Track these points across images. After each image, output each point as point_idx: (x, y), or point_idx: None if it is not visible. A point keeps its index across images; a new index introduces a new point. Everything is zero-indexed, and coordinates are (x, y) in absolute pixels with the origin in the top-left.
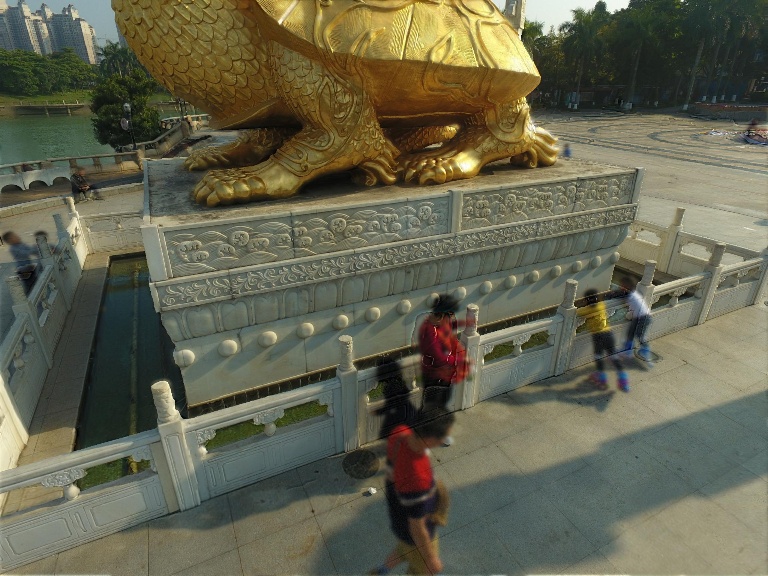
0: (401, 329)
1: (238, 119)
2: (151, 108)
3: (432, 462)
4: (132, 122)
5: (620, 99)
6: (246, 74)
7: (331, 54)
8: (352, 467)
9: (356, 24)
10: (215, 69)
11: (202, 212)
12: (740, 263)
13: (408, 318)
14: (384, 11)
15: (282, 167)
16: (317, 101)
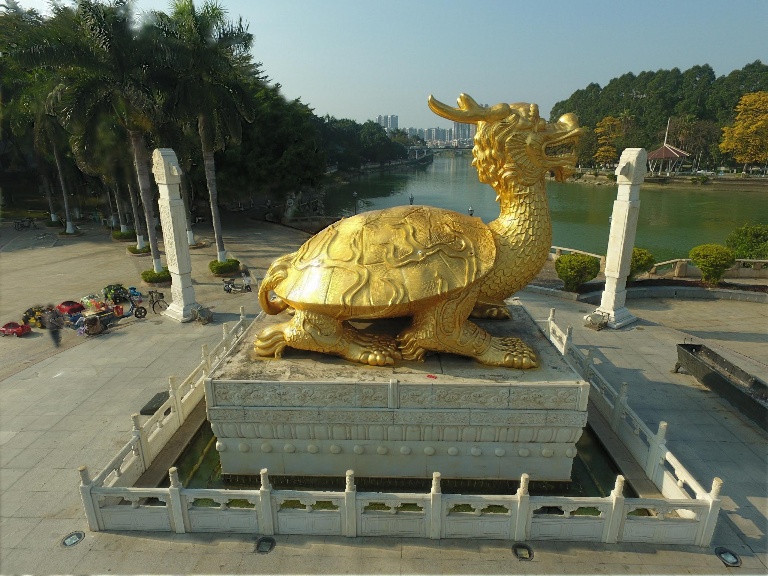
0: None
1: None
2: None
3: None
4: None
5: None
6: None
7: None
8: None
9: None
10: None
11: None
12: None
13: None
14: None
15: None
16: None
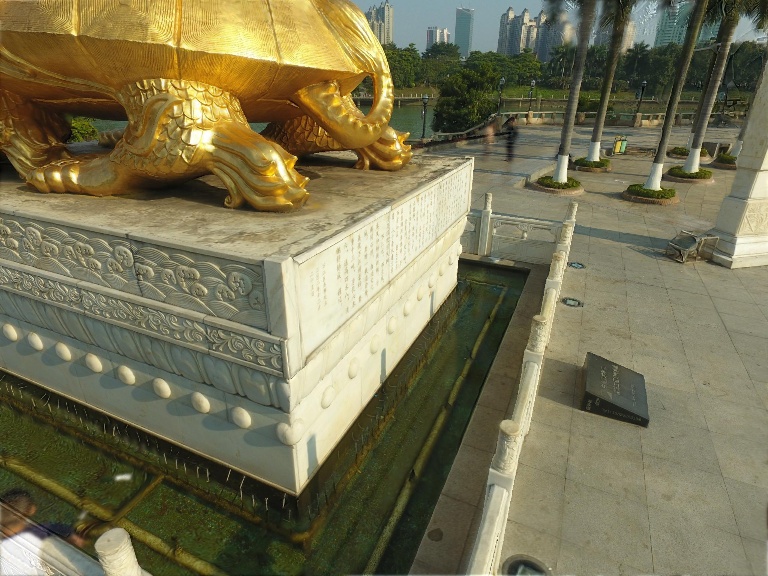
0: None
1: None
2: (495, 102)
3: None
4: (458, 114)
5: None
6: None
7: None
8: None
9: None
10: None
11: None
12: None
13: None
14: None
15: None
16: None
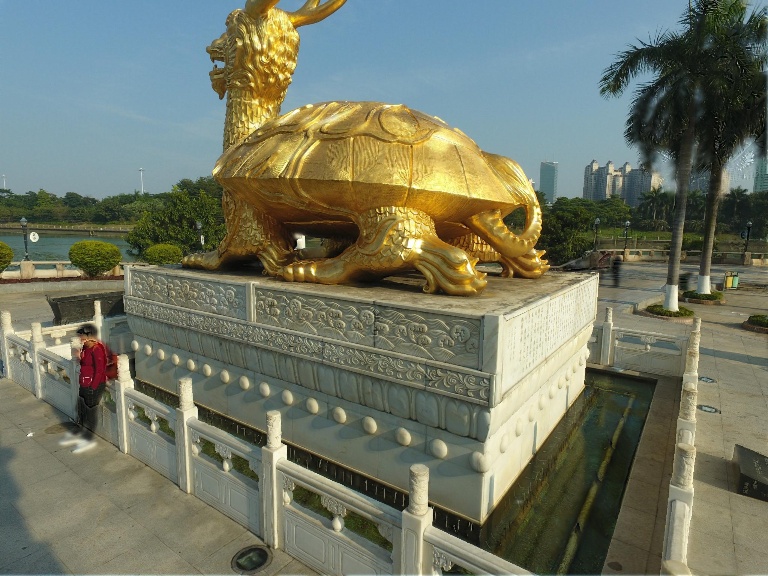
0: (225, 397)
1: None
2: (590, 240)
3: (54, 449)
4: (553, 250)
5: None
6: None
7: None
8: (58, 426)
9: None
10: None
11: (171, 268)
12: (510, 565)
13: (229, 389)
14: (251, 145)
15: None
16: None
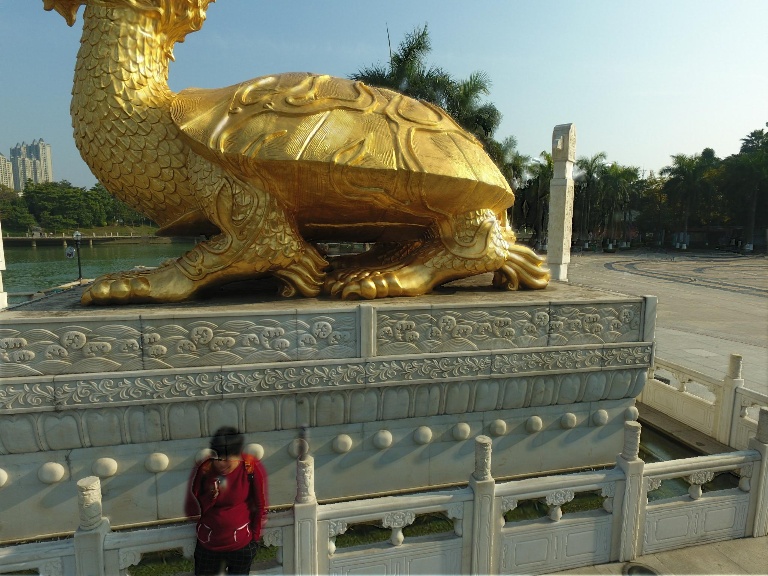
0: None
1: (167, 224)
2: None
3: None
4: None
5: (737, 240)
6: (174, 181)
7: (221, 155)
8: None
9: (256, 128)
10: (144, 176)
11: (64, 310)
12: None
13: None
14: (292, 116)
15: (178, 270)
16: (214, 202)
